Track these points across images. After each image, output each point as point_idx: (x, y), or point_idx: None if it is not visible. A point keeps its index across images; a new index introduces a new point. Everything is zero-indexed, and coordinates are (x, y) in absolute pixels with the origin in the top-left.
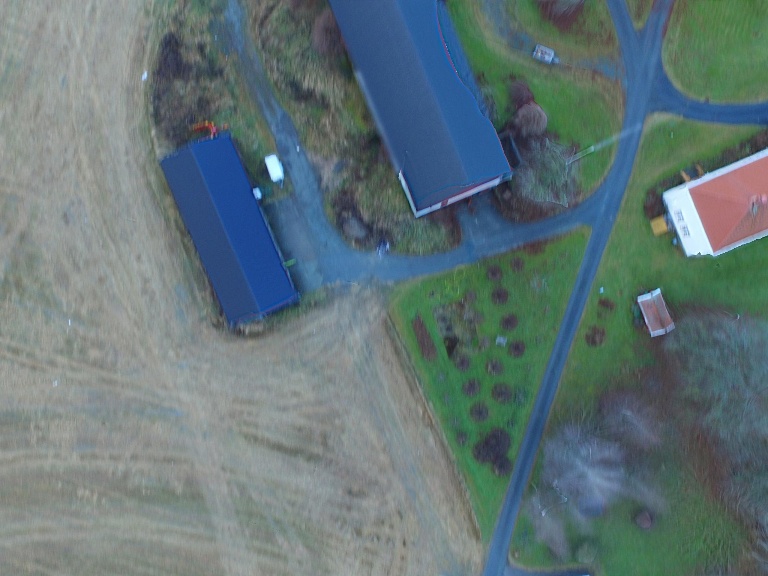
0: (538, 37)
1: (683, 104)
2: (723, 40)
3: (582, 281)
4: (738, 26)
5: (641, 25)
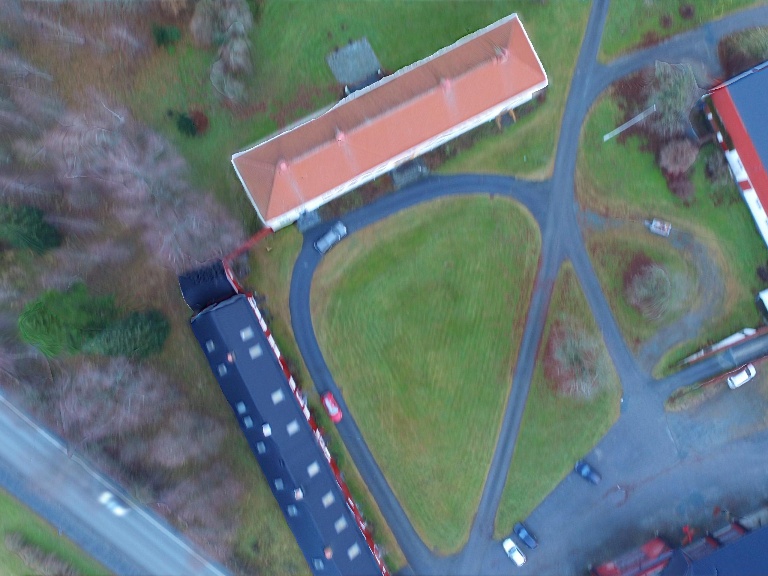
0: (665, 246)
1: (516, 191)
2: (482, 257)
3: (603, 7)
4: (468, 272)
5: (565, 265)
